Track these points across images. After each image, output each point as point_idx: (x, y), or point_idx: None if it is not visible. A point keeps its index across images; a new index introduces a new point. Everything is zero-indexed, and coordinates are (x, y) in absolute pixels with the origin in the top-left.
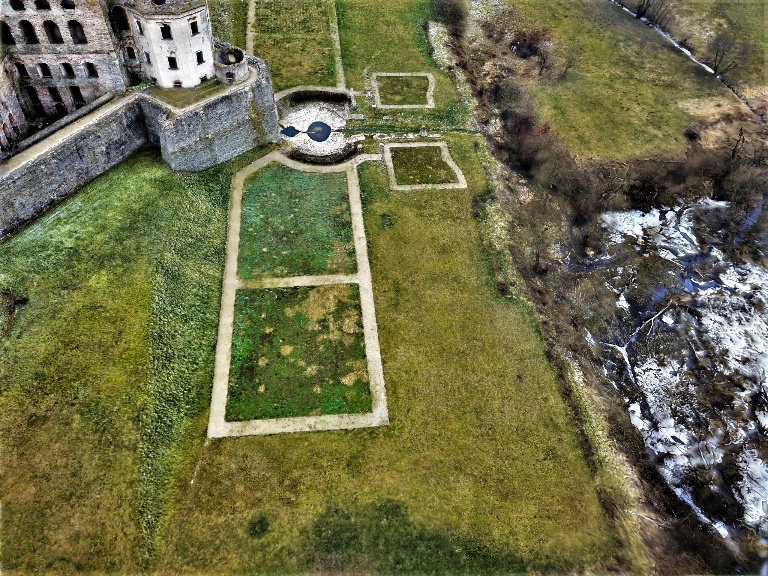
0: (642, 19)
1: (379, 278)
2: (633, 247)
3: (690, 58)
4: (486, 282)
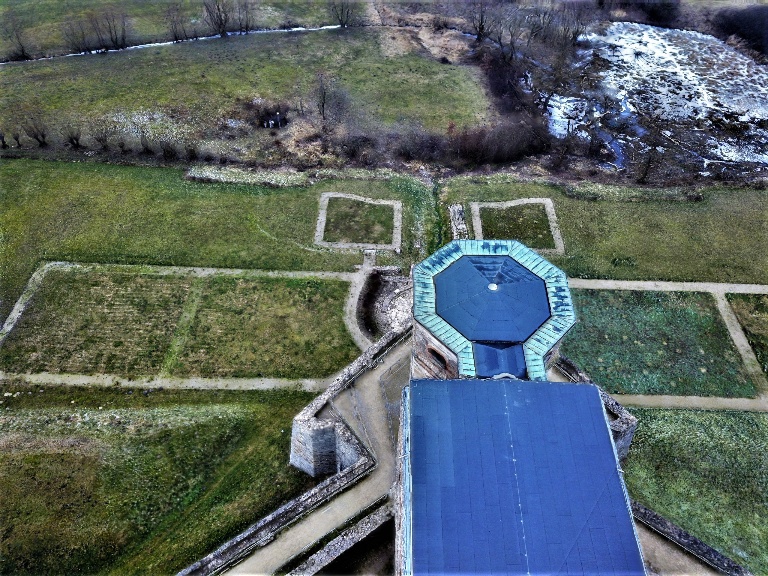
0: (229, 34)
1: (712, 277)
2: (592, 129)
3: (311, 30)
4: (690, 207)
